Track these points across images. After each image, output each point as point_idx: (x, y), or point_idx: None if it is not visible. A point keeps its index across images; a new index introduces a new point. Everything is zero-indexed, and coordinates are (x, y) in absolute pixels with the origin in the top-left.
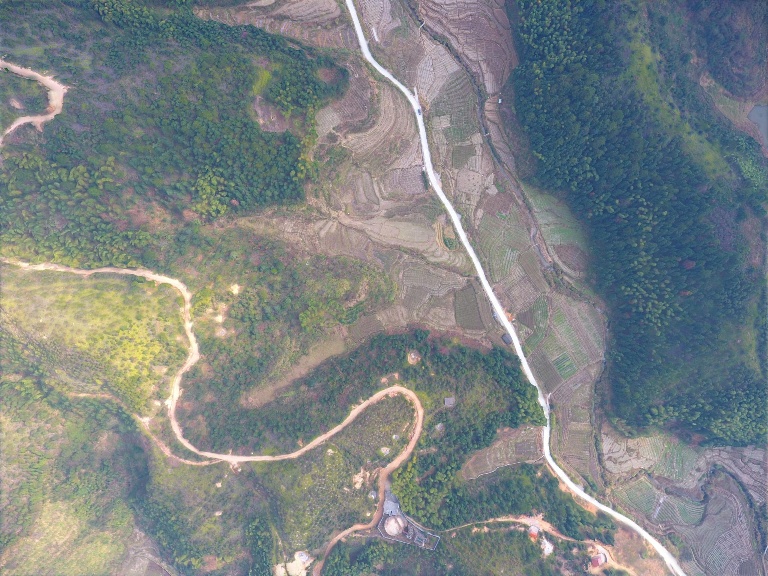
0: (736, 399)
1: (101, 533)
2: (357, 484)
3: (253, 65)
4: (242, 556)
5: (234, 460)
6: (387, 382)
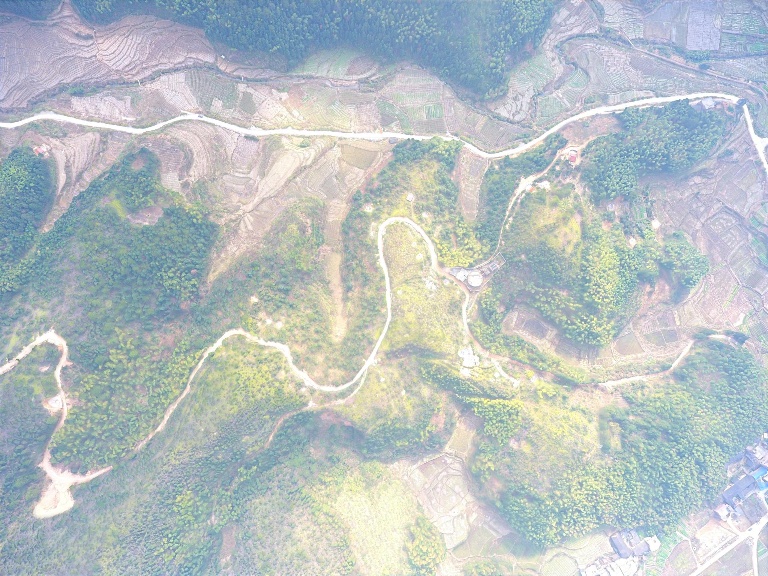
0: (509, 5)
1: (378, 487)
2: (432, 287)
3: (103, 208)
4: (445, 397)
5: (371, 361)
6: (374, 232)
